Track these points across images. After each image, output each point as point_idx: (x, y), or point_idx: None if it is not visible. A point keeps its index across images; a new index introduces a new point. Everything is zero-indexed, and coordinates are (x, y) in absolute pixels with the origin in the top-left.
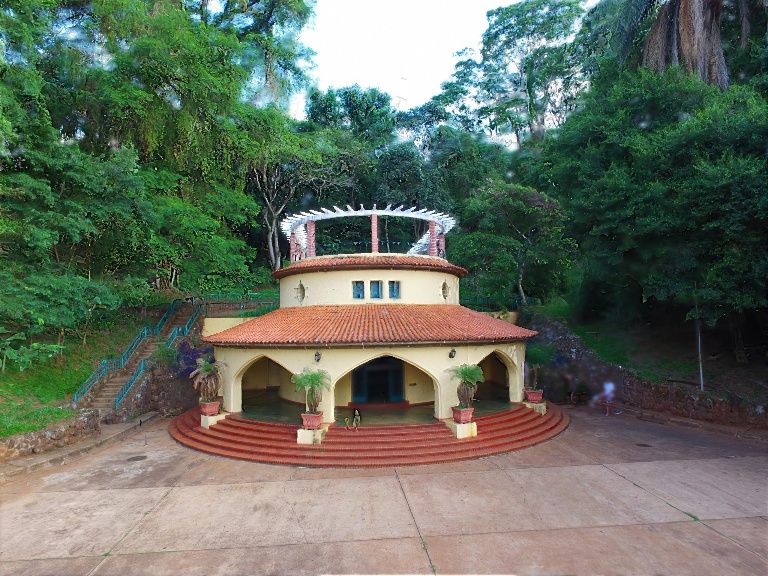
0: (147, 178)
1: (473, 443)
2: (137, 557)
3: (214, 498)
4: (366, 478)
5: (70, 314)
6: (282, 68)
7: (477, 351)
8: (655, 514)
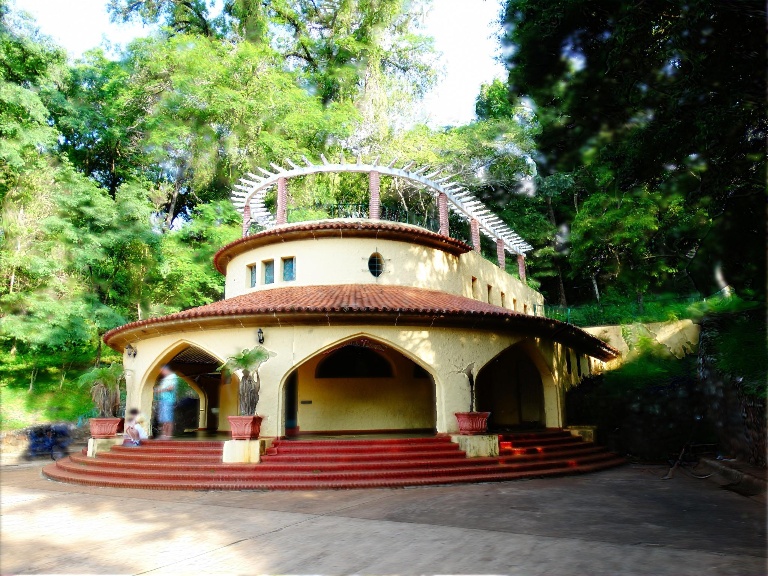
0: (205, 210)
1: (235, 471)
2: None
3: None
4: None
5: (57, 334)
6: (401, 70)
7: (313, 334)
8: None
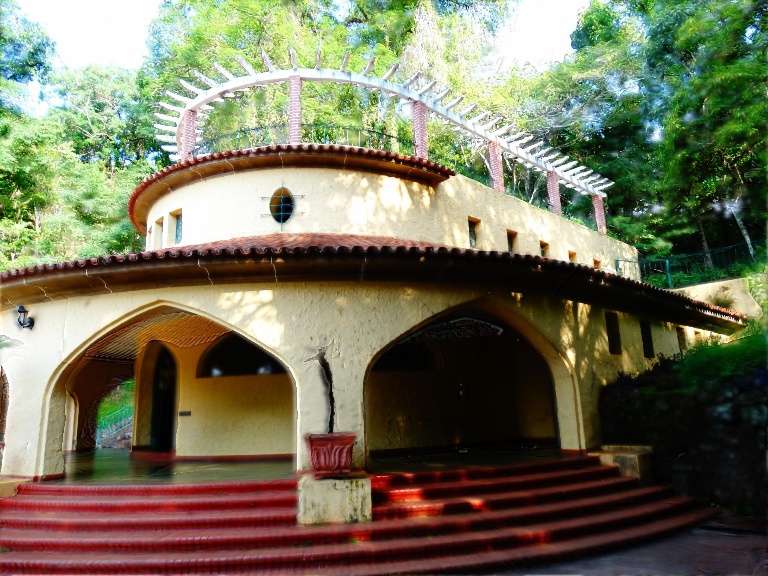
0: None
1: None
2: None
3: None
4: None
5: None
6: (464, 7)
7: (91, 308)
8: None
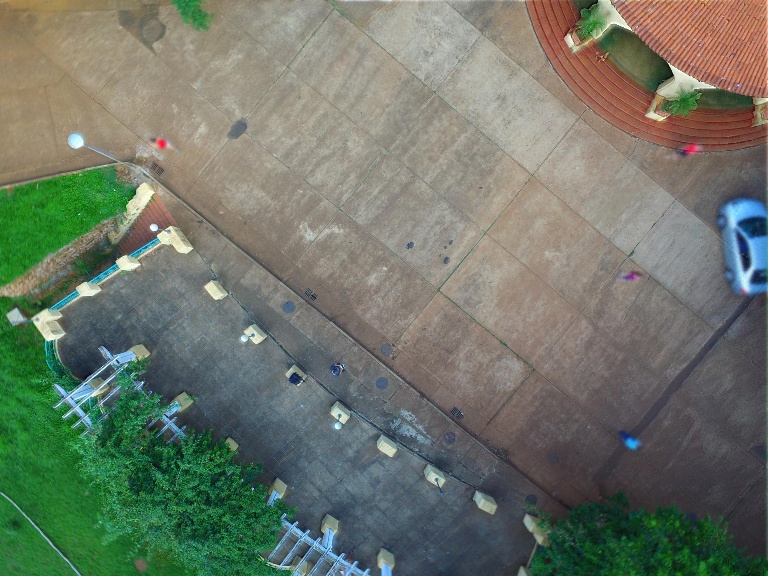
0: None
1: (649, 125)
2: (443, 103)
3: (490, 68)
4: (564, 107)
5: None
6: None
7: None
8: (622, 241)
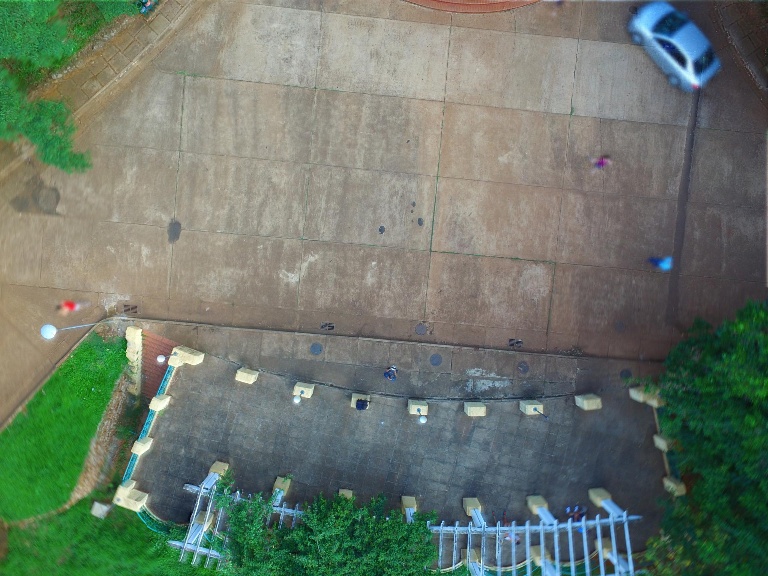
0: None
1: None
2: (328, 93)
3: (348, 36)
4: (432, 26)
5: None
6: None
7: None
8: (557, 105)
